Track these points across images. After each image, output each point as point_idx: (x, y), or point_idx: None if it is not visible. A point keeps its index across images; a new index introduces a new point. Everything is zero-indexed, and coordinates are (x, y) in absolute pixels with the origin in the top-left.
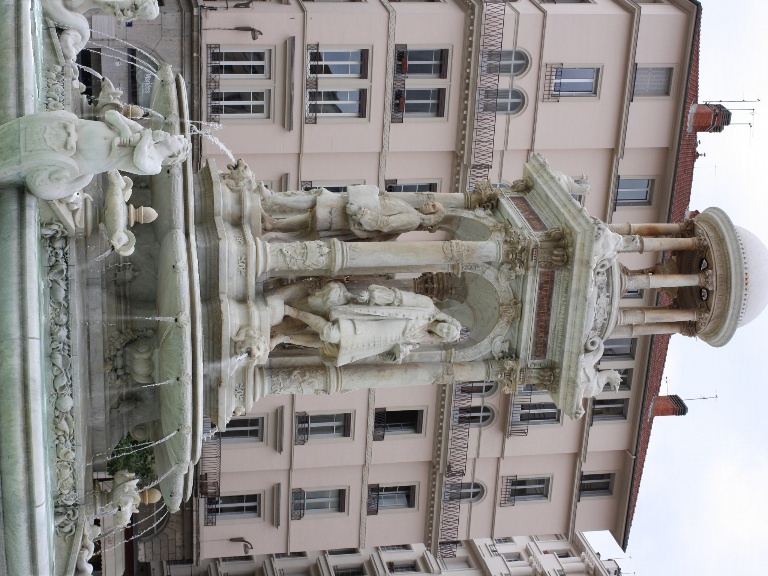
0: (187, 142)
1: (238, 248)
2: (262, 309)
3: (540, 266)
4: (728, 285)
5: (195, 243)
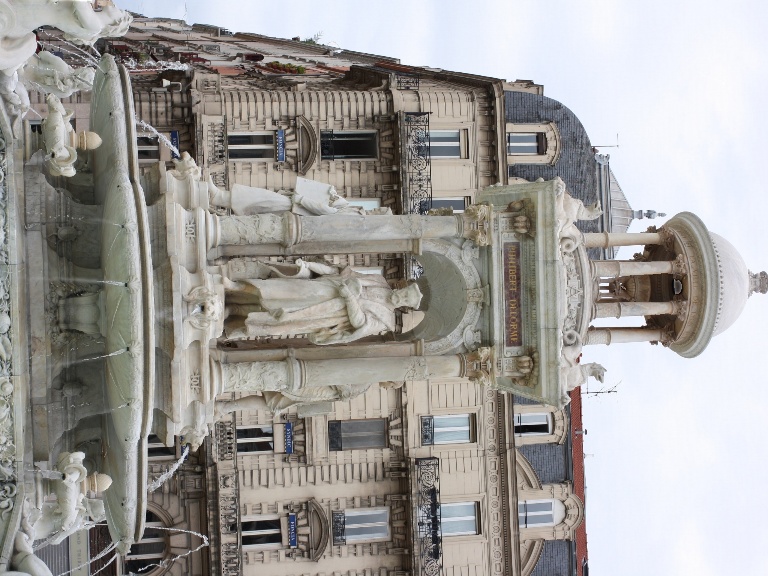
0: None
1: None
2: None
3: None
4: None
5: None
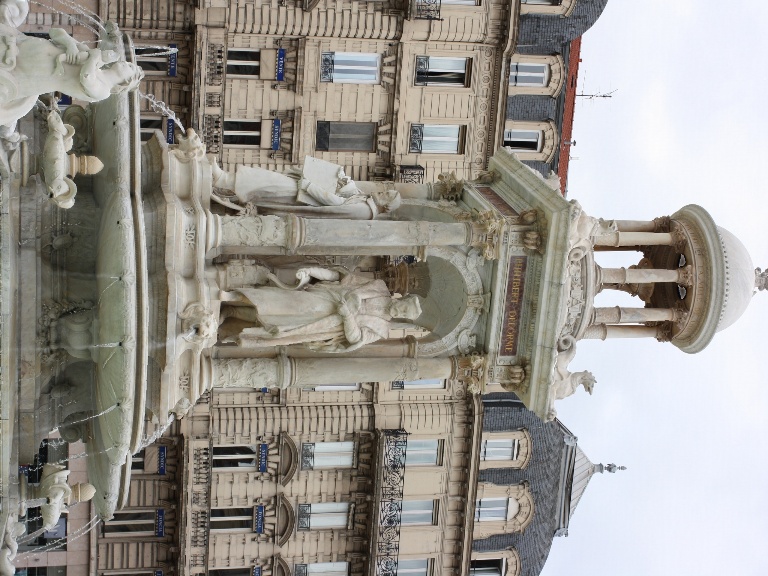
0: None
1: None
2: None
3: None
4: None
5: None
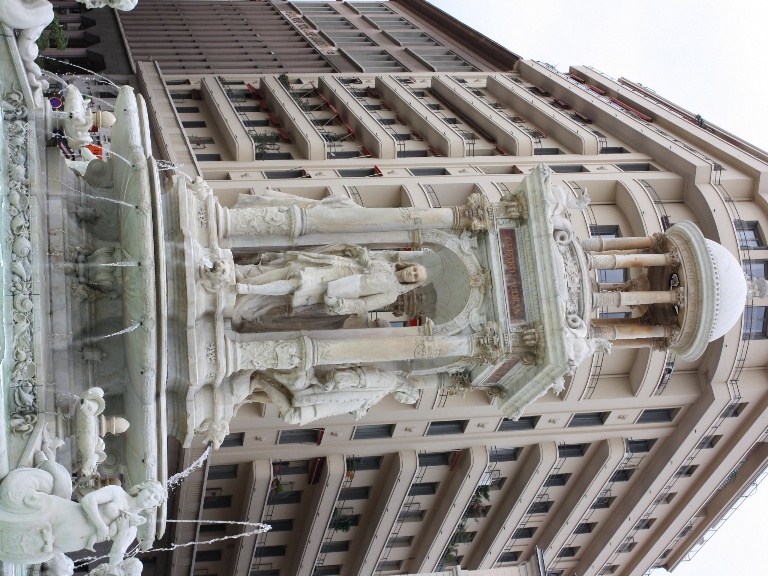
0: (163, 495)
1: (208, 371)
2: (227, 401)
3: (508, 358)
4: (690, 340)
5: (165, 409)
